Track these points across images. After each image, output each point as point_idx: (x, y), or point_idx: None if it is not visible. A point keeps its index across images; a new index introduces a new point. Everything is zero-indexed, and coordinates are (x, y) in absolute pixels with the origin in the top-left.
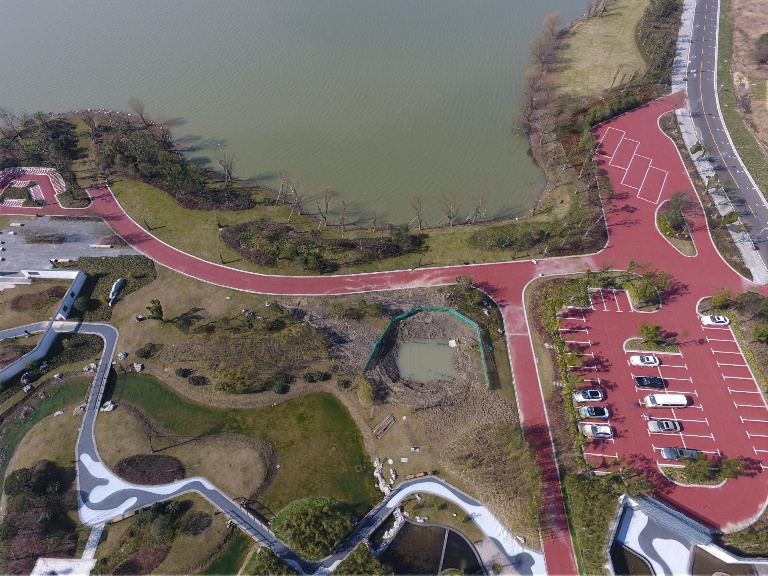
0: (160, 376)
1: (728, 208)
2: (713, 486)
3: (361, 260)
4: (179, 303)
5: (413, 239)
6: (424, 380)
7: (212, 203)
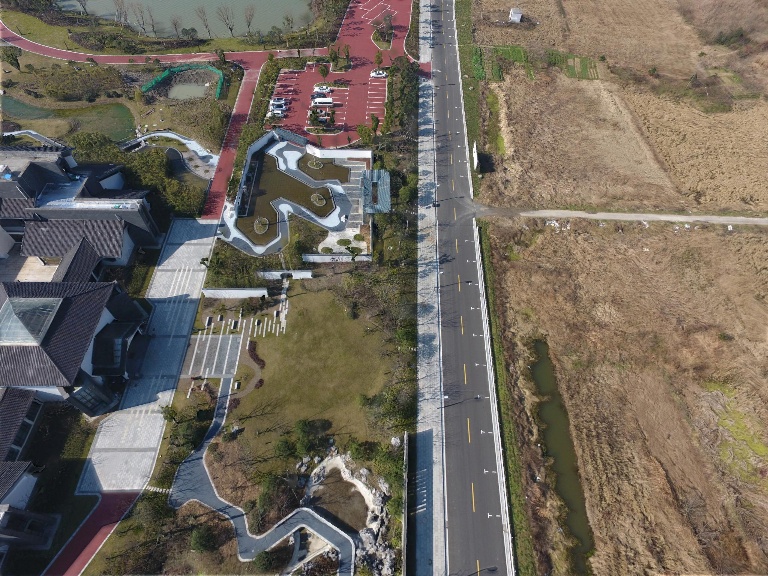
0: (15, 96)
1: (427, 29)
2: (332, 134)
3: (162, 49)
4: (34, 65)
5: (201, 40)
6: (182, 99)
7: (68, 23)
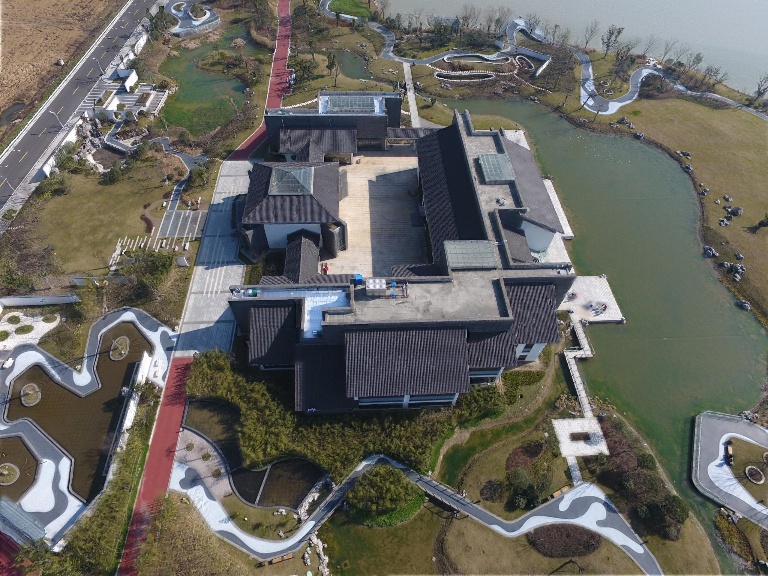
0: None
1: None
2: None
3: None
4: None
5: None
6: None
7: None
